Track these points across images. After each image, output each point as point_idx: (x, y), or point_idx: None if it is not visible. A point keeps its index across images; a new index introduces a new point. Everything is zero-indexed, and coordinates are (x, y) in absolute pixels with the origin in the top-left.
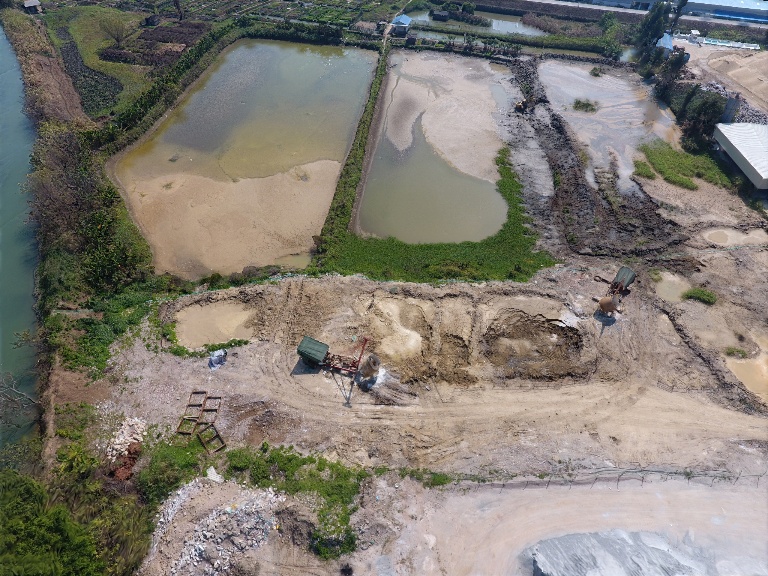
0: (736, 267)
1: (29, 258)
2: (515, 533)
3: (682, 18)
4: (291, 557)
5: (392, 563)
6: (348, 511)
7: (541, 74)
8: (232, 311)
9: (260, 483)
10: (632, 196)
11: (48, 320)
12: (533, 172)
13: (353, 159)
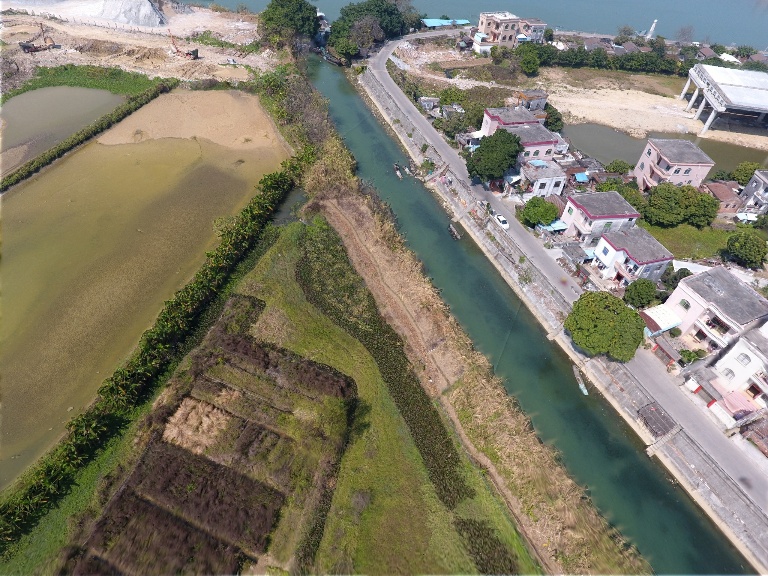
0: None
1: None
2: None
3: None
4: None
5: None
6: None
7: None
8: None
9: None
10: None
11: None
12: None
13: (86, 129)
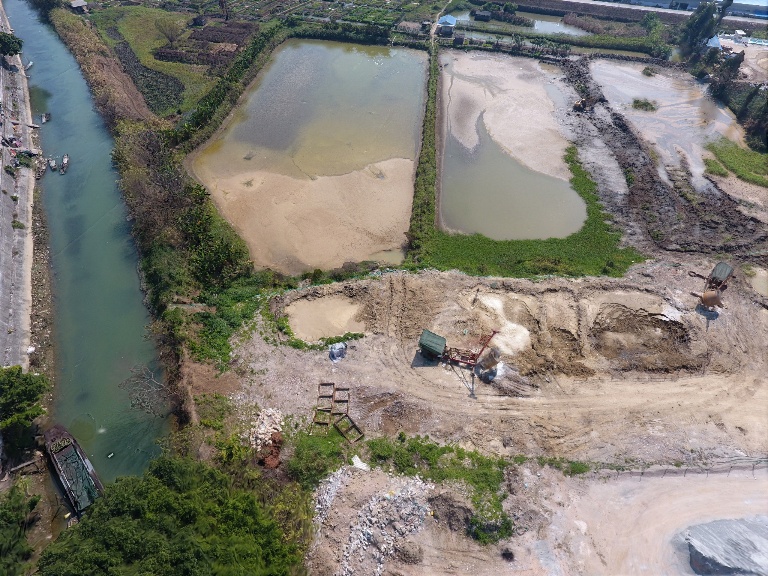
0: None
1: (129, 254)
2: (663, 519)
3: (724, 18)
4: (451, 542)
5: (550, 548)
6: (498, 498)
7: (594, 74)
8: (340, 305)
9: (406, 471)
10: (709, 193)
11: (168, 314)
12: (604, 170)
13: (427, 157)
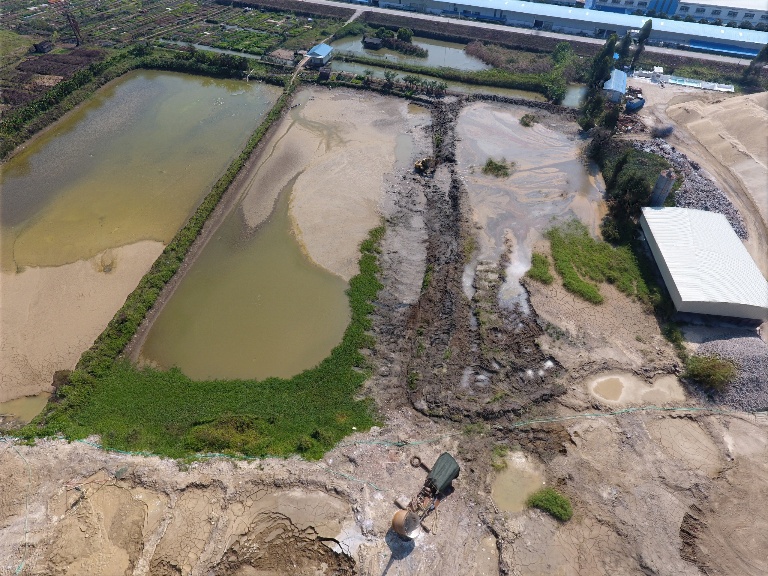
0: (619, 447)
1: None
2: None
3: (649, 50)
4: None
5: None
6: None
7: (460, 122)
8: None
9: None
10: (512, 312)
11: None
12: (403, 264)
13: (175, 243)
